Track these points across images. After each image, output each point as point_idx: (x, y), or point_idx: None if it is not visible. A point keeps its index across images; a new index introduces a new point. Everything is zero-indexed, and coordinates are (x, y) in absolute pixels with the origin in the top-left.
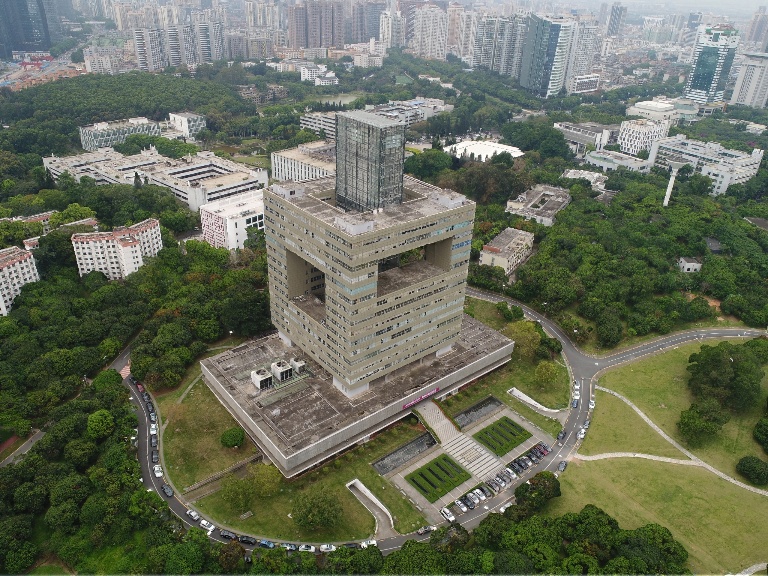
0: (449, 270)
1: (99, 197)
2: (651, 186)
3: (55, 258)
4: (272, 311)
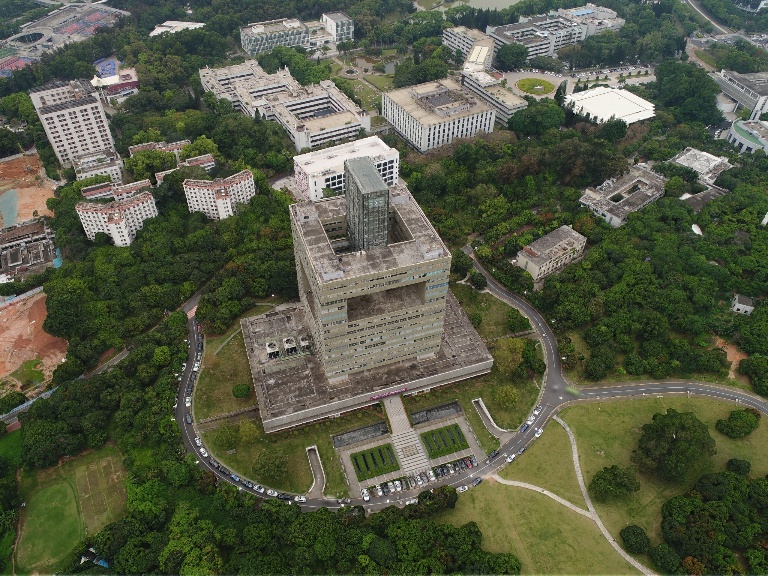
0: (424, 304)
1: (223, 130)
2: (765, 193)
3: (173, 195)
4: (299, 291)
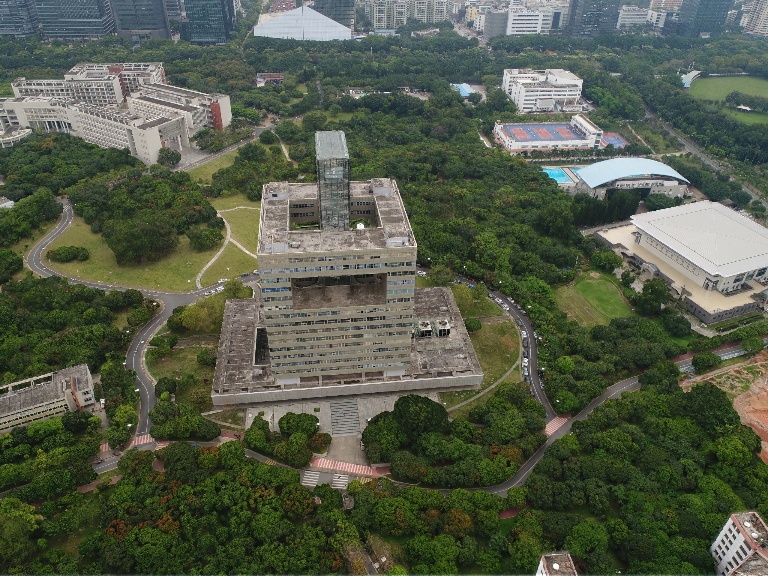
0: None
1: None
2: None
3: None
4: None
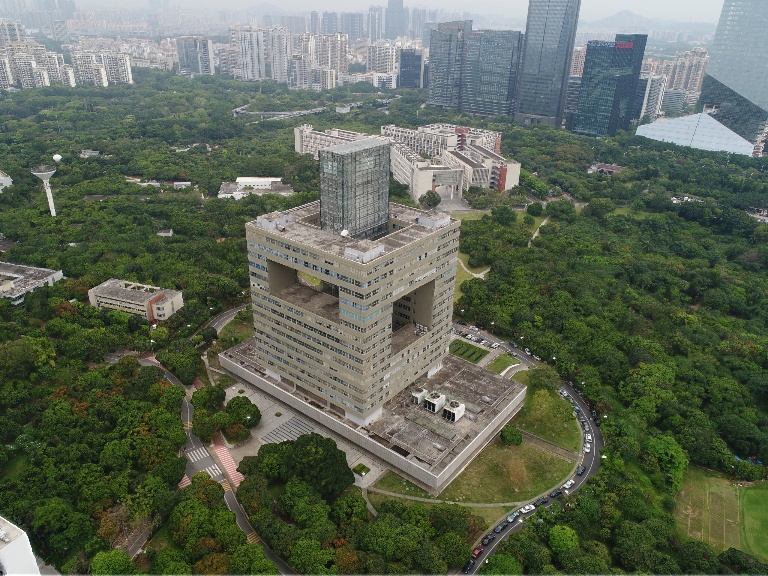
0: None
1: None
2: (2, 213)
3: None
4: (366, 402)
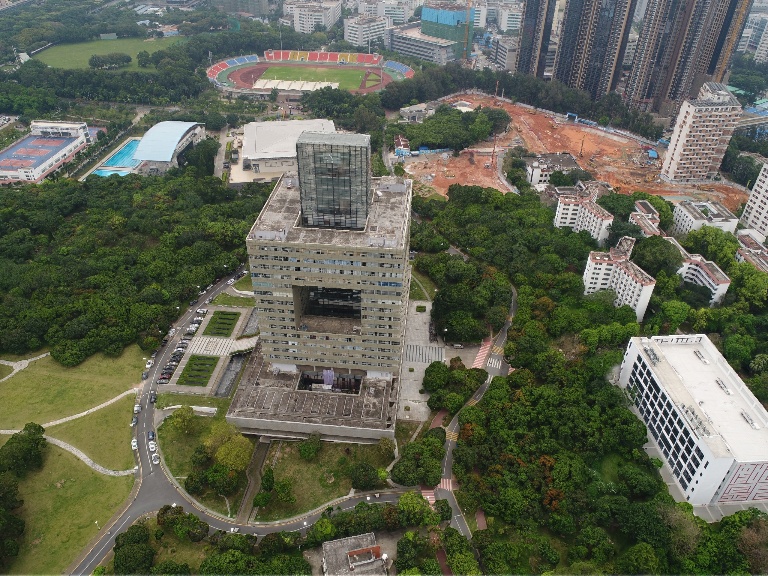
0: None
1: None
2: None
3: None
4: None
